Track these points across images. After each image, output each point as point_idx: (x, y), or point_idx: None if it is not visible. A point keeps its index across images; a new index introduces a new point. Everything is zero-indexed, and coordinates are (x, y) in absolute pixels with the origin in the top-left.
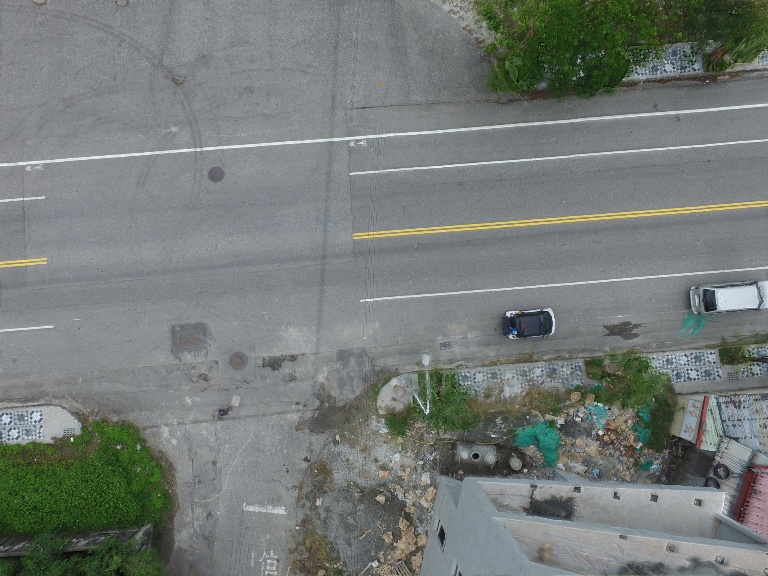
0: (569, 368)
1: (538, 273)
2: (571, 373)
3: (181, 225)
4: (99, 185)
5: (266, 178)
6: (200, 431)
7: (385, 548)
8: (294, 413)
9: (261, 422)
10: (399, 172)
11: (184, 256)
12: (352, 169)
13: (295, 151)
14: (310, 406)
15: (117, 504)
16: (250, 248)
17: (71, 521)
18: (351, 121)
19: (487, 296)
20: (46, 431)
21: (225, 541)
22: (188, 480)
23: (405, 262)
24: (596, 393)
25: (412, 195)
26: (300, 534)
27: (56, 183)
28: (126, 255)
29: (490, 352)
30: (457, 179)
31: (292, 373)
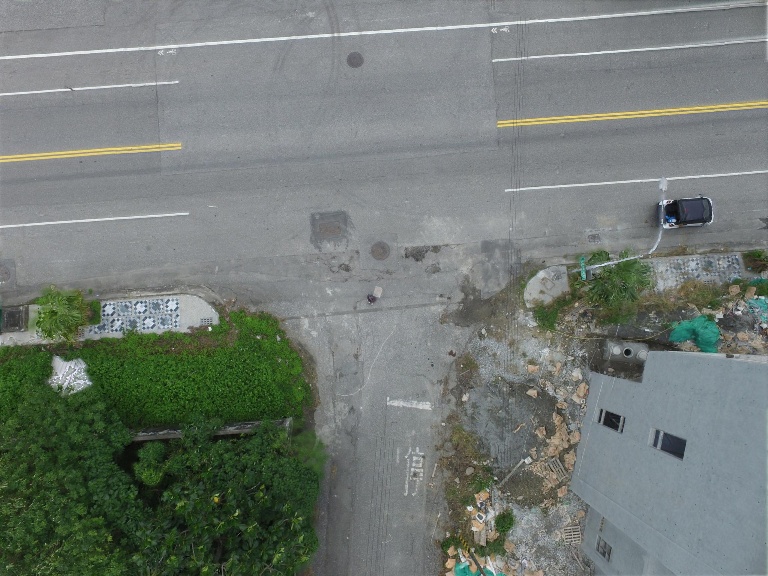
0: (726, 261)
1: (691, 163)
2: (728, 266)
3: (319, 111)
4: (234, 70)
5: (406, 64)
6: (341, 323)
7: (538, 444)
8: (438, 306)
9: (404, 314)
10: (544, 59)
11: (323, 143)
12: (495, 56)
13: (436, 37)
14: (454, 299)
15: (262, 392)
16: (391, 135)
17: (214, 409)
18: (493, 7)
19: (638, 187)
20: (183, 320)
21: (369, 436)
22: (329, 373)
23: (552, 151)
24: (757, 285)
25: (558, 83)
26: (446, 430)
27: (190, 67)
28: (263, 141)
29: (641, 245)
30: (605, 66)
31: (435, 264)
